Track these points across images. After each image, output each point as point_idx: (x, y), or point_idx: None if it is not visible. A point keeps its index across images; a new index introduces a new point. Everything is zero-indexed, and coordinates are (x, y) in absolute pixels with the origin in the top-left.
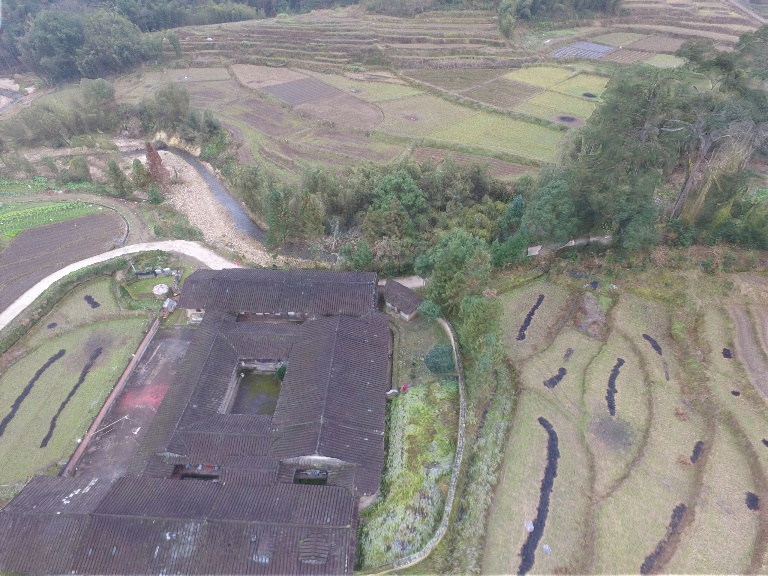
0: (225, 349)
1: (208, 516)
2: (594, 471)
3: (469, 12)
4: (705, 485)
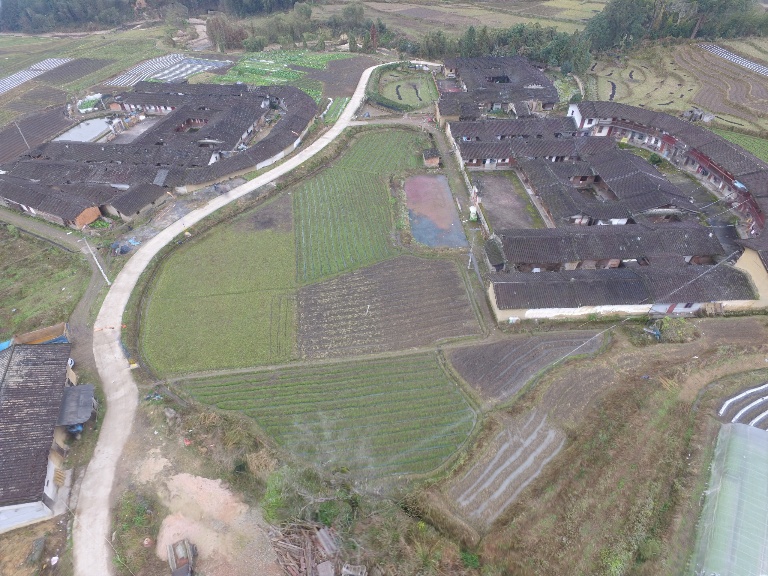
0: None
1: None
2: (628, 86)
3: None
4: None
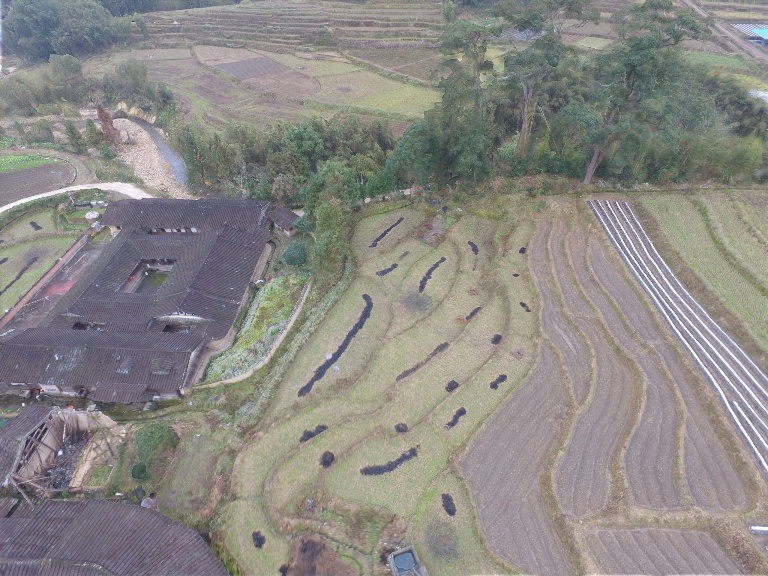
0: (131, 251)
1: (88, 345)
2: (390, 325)
3: None
4: (465, 330)
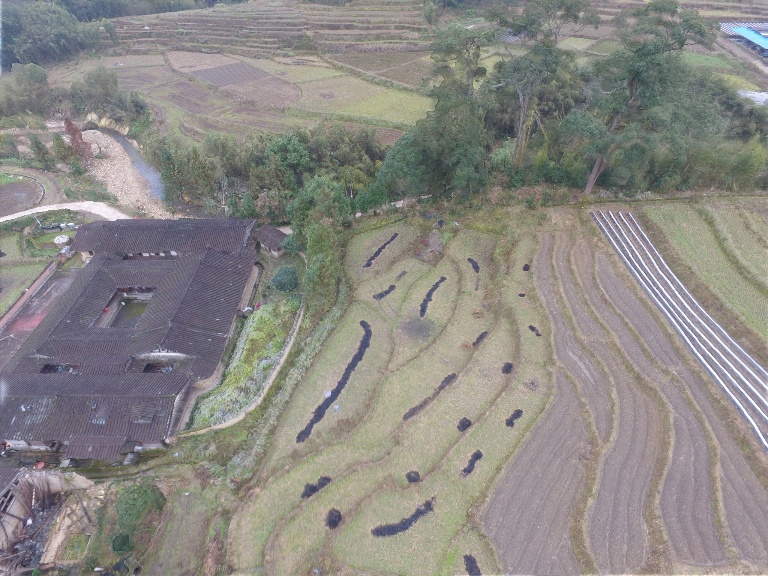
0: (105, 280)
1: (59, 393)
2: (392, 355)
3: (397, 0)
4: (474, 359)
